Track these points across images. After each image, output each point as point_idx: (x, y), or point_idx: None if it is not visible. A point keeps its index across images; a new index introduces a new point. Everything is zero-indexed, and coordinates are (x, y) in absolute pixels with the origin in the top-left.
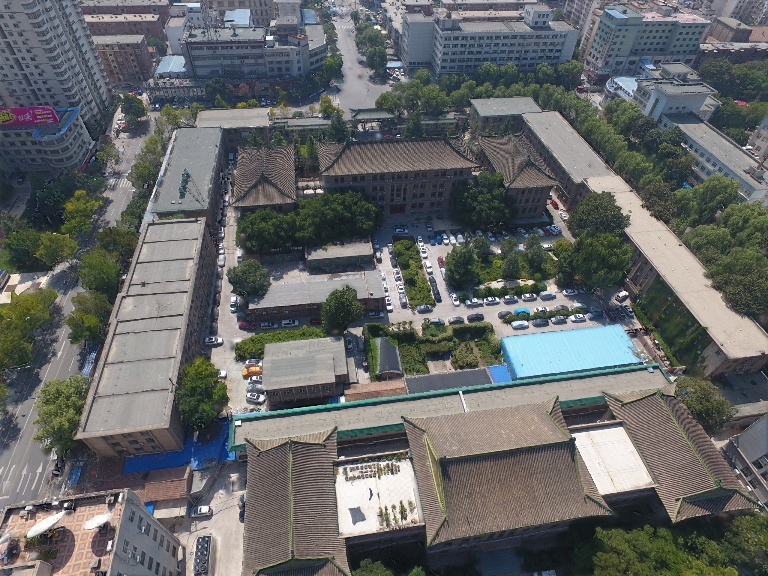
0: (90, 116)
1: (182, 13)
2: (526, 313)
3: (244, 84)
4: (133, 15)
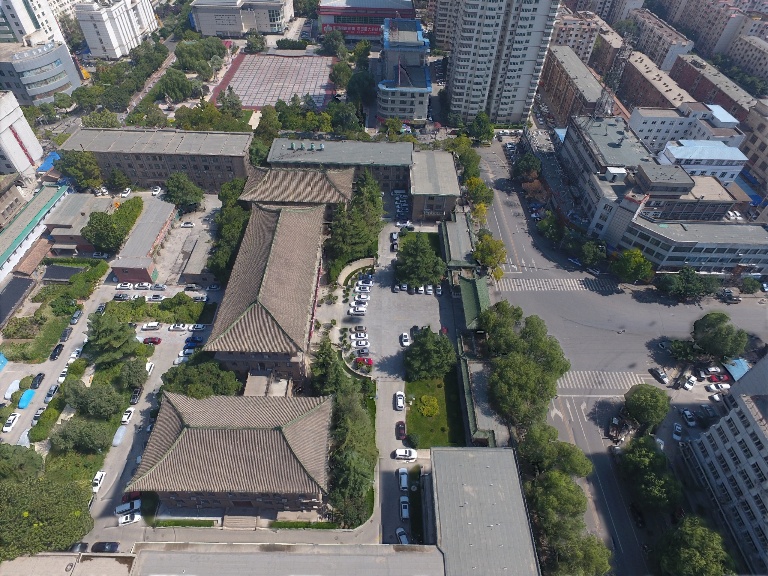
0: (465, 111)
1: (688, 113)
2: (20, 400)
3: (538, 182)
4: (679, 93)
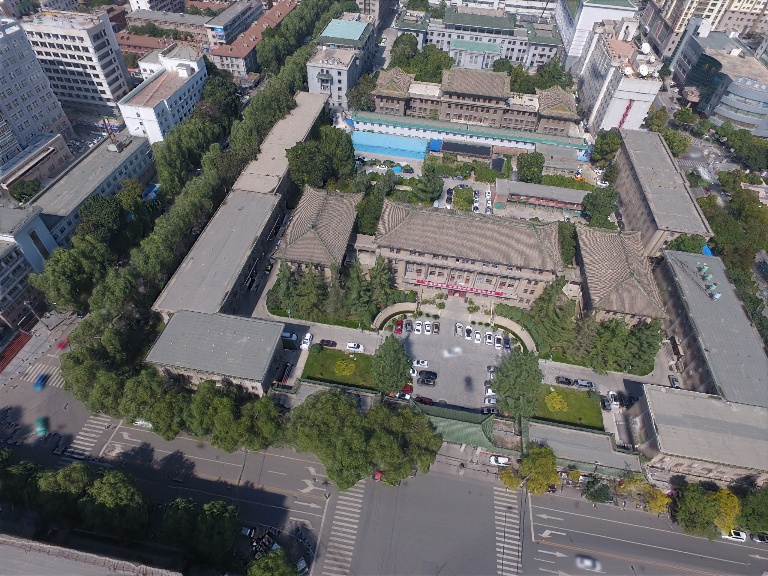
0: None
1: None
2: None
3: None
4: None
